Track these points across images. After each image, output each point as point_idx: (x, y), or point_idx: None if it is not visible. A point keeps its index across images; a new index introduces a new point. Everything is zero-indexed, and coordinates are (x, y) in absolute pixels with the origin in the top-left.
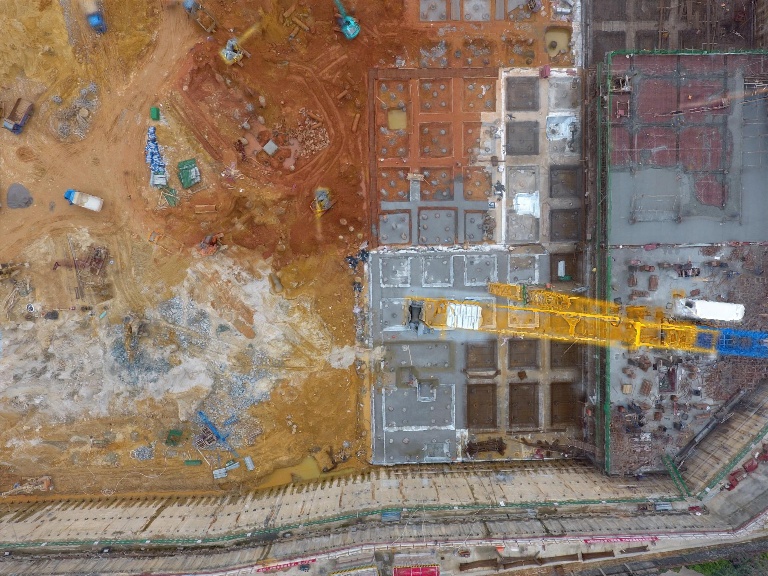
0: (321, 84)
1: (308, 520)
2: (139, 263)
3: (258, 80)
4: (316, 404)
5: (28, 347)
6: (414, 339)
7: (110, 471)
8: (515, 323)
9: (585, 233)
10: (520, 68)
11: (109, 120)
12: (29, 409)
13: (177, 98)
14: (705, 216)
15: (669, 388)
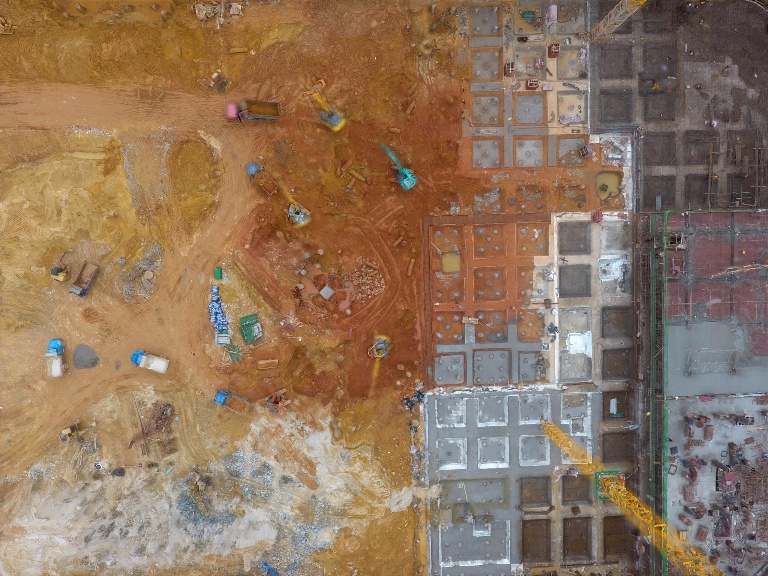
0: (378, 233)
1: None
2: (204, 419)
3: (317, 234)
4: (377, 550)
5: (97, 506)
6: (470, 477)
7: None
8: (568, 459)
9: (637, 372)
10: (572, 213)
11: (173, 280)
12: None
13: (239, 256)
14: (759, 366)
15: (723, 530)
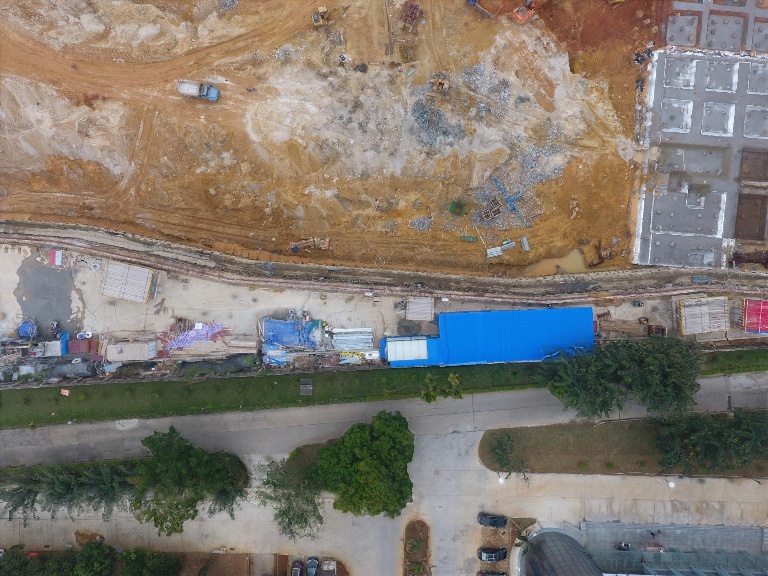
0: None
1: (620, 275)
2: (450, 26)
3: None
4: (603, 187)
5: (339, 94)
6: (691, 142)
7: (385, 240)
8: None
9: None
10: None
11: None
12: (331, 157)
13: None
14: None
15: None
